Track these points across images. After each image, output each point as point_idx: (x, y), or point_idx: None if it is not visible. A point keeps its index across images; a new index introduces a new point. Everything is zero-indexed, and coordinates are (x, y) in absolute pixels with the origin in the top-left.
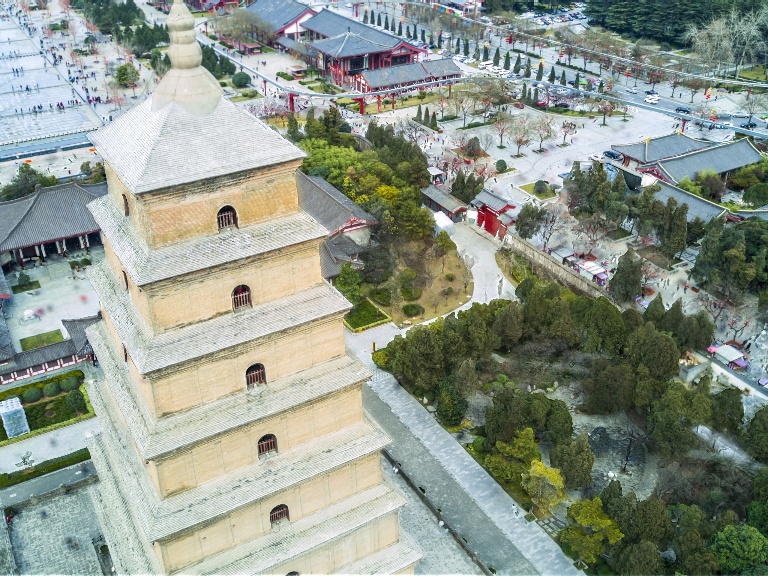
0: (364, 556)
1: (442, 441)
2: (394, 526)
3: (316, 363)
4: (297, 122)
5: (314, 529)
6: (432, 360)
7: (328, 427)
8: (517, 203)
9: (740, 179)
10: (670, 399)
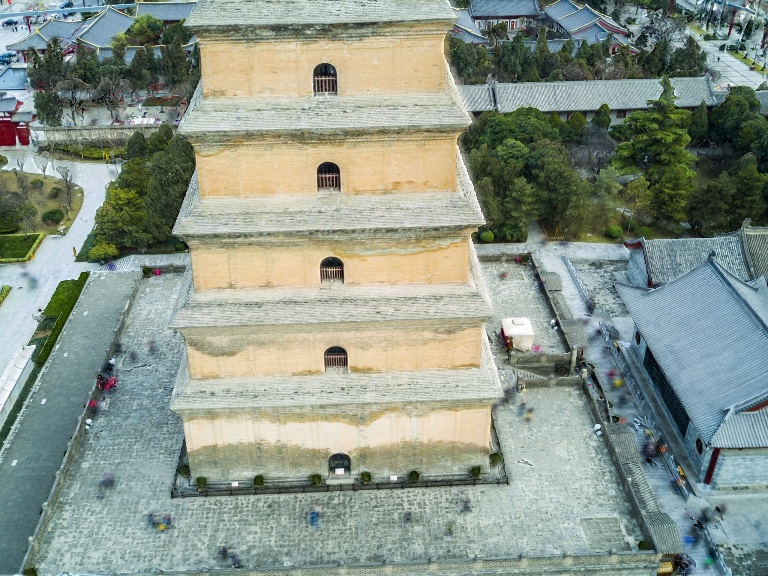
0: None
1: None
2: None
3: None
4: None
5: None
6: None
7: None
8: None
9: (139, 36)
10: None
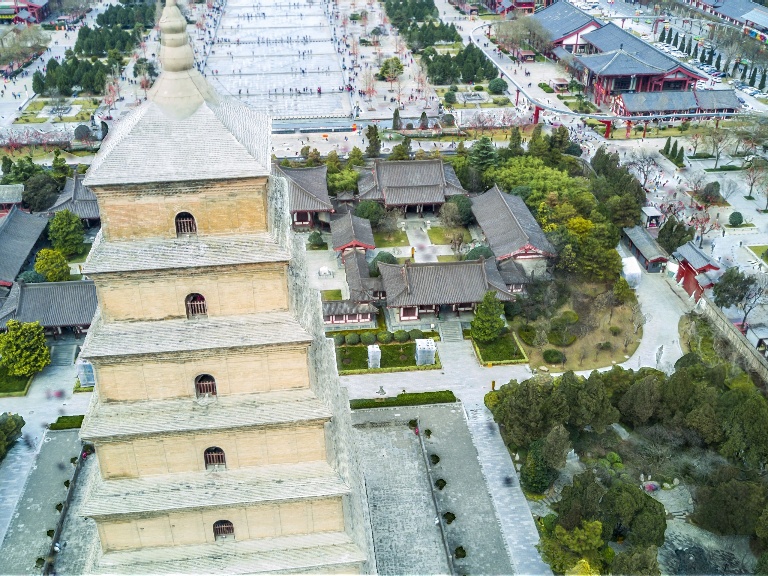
0: None
1: (514, 505)
2: None
3: (274, 389)
4: (521, 137)
5: (258, 555)
6: (528, 416)
7: (284, 457)
8: (723, 264)
9: None
10: None
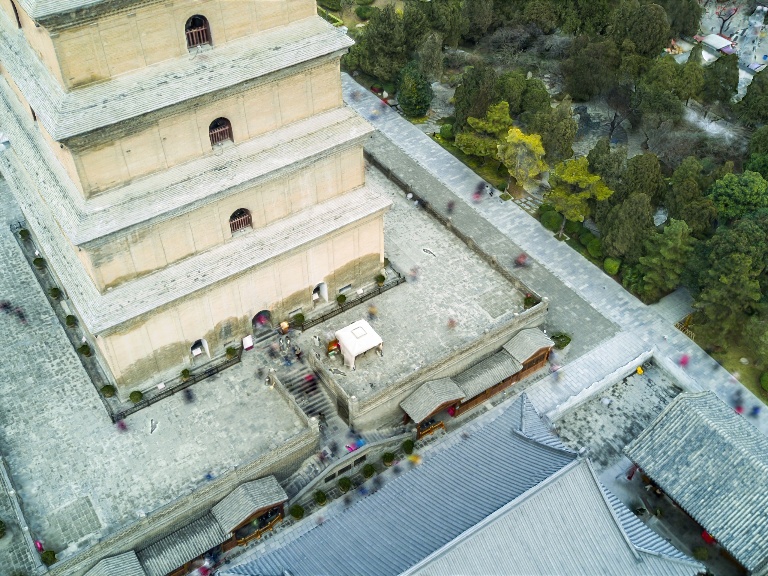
0: (325, 199)
1: (406, 132)
2: (359, 164)
3: None
4: None
5: (264, 154)
6: (392, 42)
7: (274, 18)
8: None
9: None
10: (659, 69)
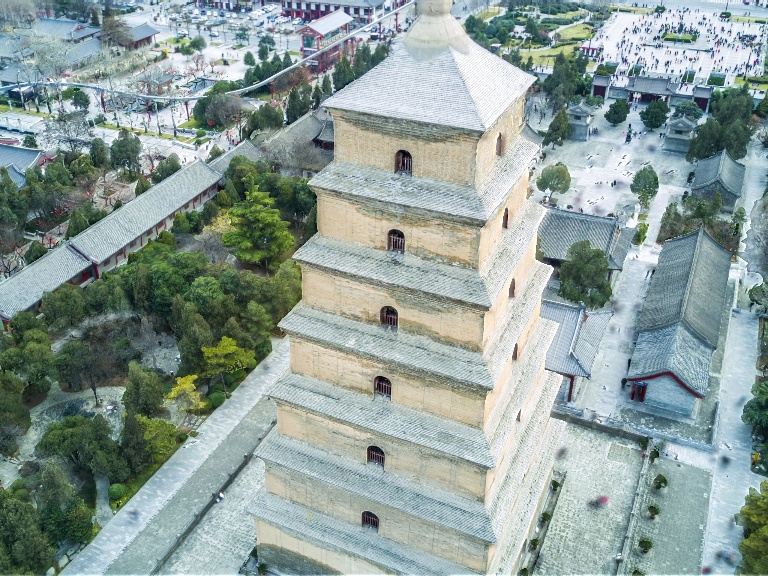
0: None
1: (120, 528)
2: None
3: None
4: None
5: None
6: None
7: None
8: None
9: None
10: None
